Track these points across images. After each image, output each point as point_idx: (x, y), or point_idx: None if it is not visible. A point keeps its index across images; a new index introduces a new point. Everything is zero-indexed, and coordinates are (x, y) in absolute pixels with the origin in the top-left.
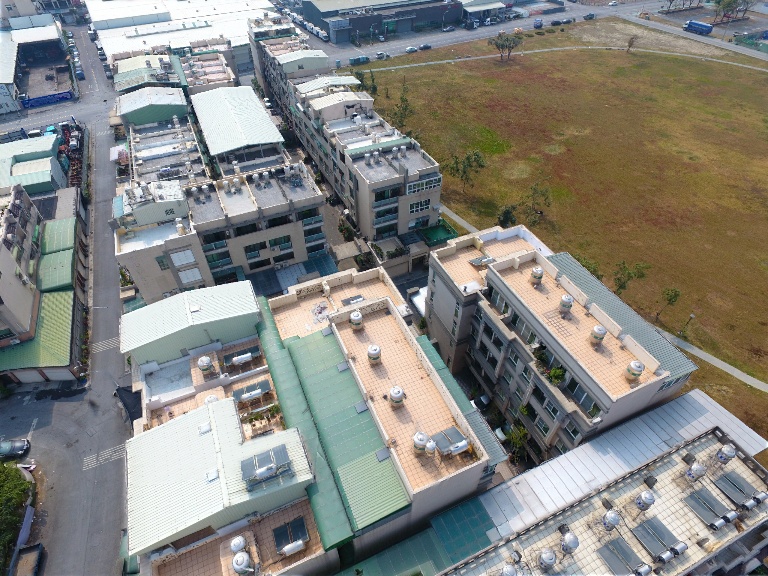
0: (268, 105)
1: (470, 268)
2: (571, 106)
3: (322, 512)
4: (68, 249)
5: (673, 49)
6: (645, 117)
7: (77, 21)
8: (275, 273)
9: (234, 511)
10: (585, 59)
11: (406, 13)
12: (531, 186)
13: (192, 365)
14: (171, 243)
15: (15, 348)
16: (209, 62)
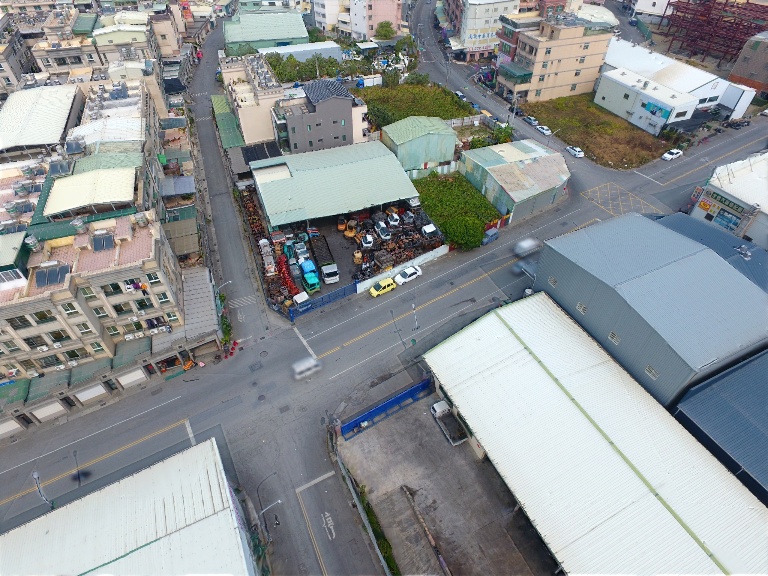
0: None
1: None
2: None
3: None
4: None
5: None
6: None
7: None
8: None
9: None
10: None
11: None
12: None
13: None
14: None
15: None
16: None
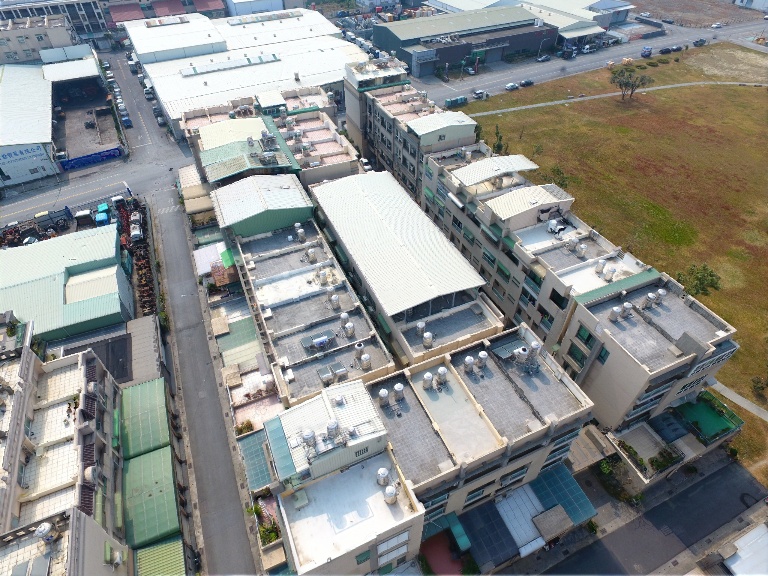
0: (368, 168)
1: None
2: (741, 168)
3: None
4: (162, 446)
5: None
6: None
7: (112, 47)
8: (498, 512)
9: None
10: (722, 99)
11: (498, 41)
12: None
13: None
14: (385, 533)
15: None
16: (309, 123)
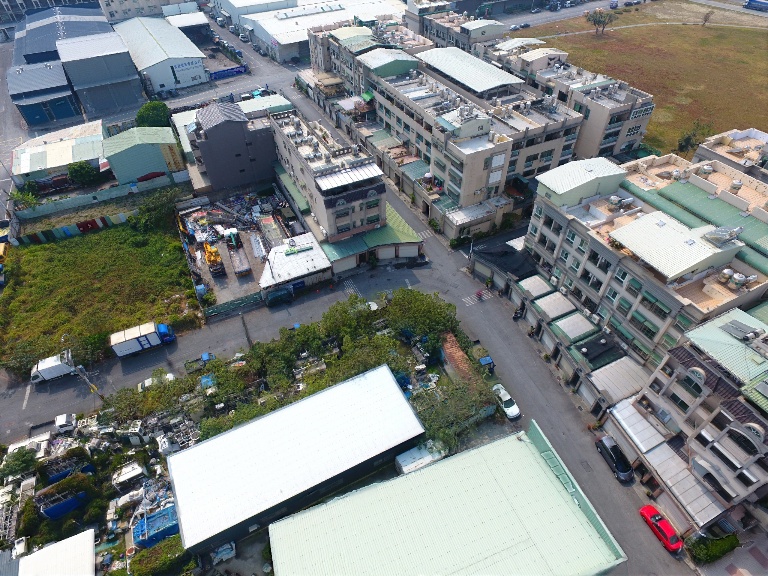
0: None
1: (730, 155)
2: (678, 69)
3: (759, 262)
4: None
5: (742, 23)
6: (745, 75)
7: None
8: None
9: (711, 260)
10: (669, 32)
11: None
12: (693, 122)
13: (595, 206)
14: (497, 147)
15: (376, 231)
16: None
